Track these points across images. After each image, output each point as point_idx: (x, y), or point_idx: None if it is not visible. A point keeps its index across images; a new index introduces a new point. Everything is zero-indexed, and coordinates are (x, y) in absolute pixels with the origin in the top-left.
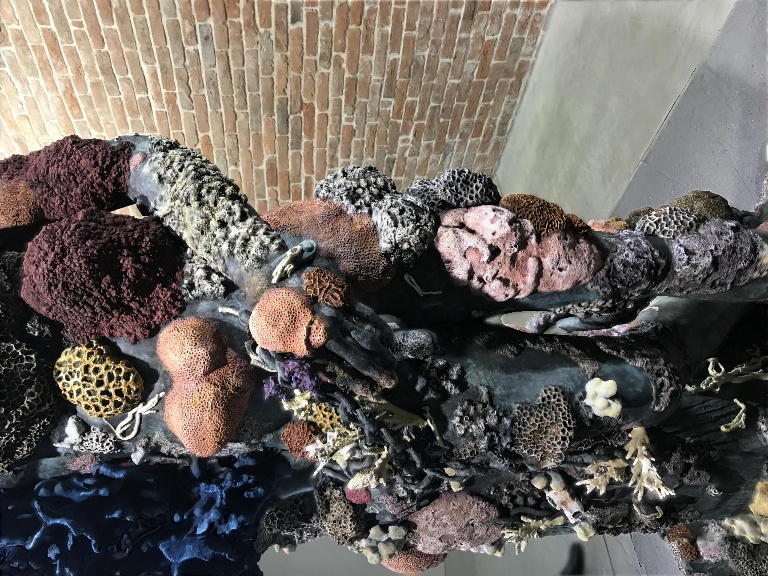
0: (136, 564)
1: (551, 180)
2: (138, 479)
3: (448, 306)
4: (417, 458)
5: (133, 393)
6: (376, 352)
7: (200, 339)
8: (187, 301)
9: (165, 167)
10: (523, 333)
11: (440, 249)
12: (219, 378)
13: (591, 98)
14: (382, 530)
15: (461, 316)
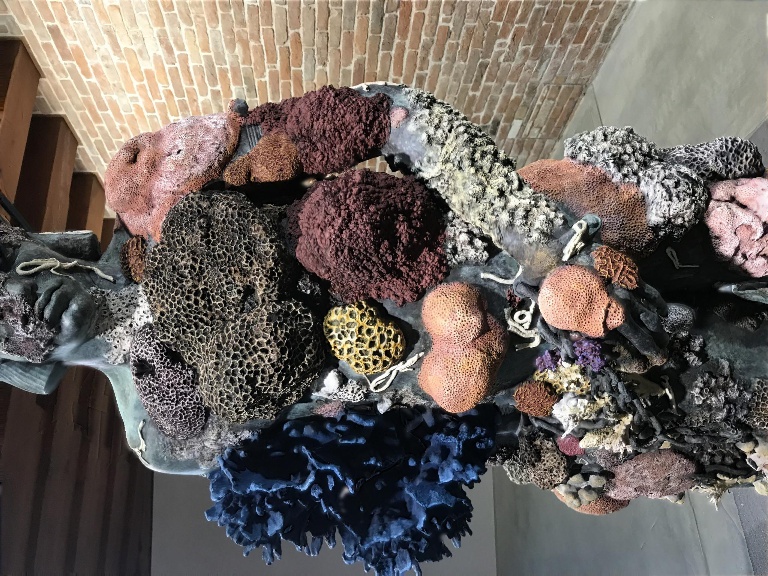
0: (370, 499)
1: (662, 96)
2: (383, 427)
3: (697, 278)
4: (659, 426)
5: (399, 353)
6: (658, 333)
7: (469, 306)
8: (451, 266)
9: (434, 127)
10: (757, 304)
11: (710, 224)
12: (484, 344)
13: (726, 9)
14: (583, 478)
15: (701, 286)
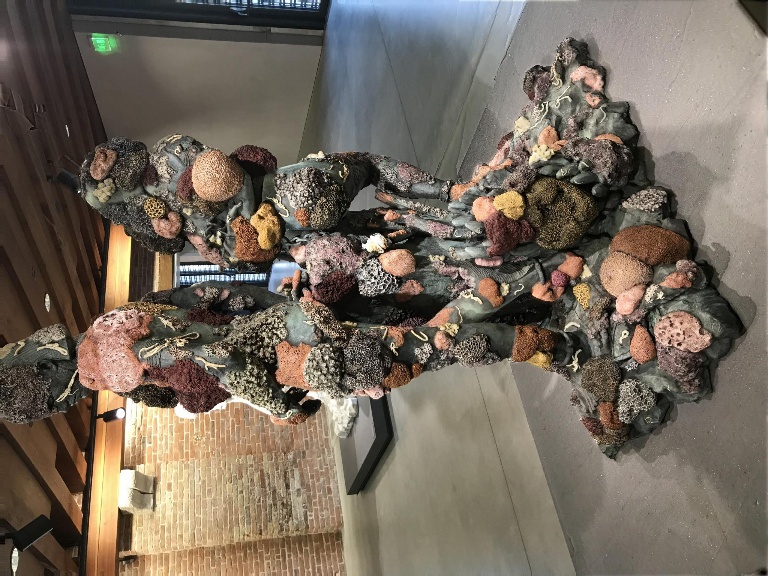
0: None
1: None
2: None
3: None
4: None
5: None
6: None
7: None
8: None
9: None
10: None
11: None
12: None
13: None
14: None
15: None
